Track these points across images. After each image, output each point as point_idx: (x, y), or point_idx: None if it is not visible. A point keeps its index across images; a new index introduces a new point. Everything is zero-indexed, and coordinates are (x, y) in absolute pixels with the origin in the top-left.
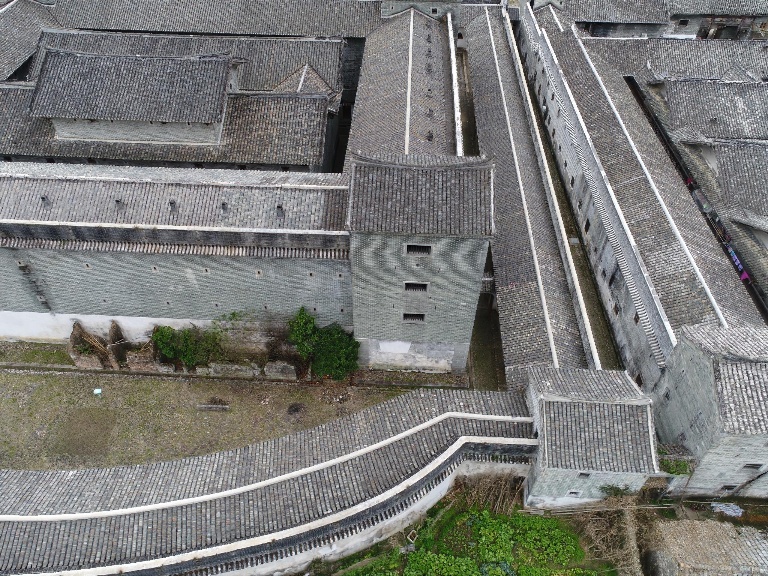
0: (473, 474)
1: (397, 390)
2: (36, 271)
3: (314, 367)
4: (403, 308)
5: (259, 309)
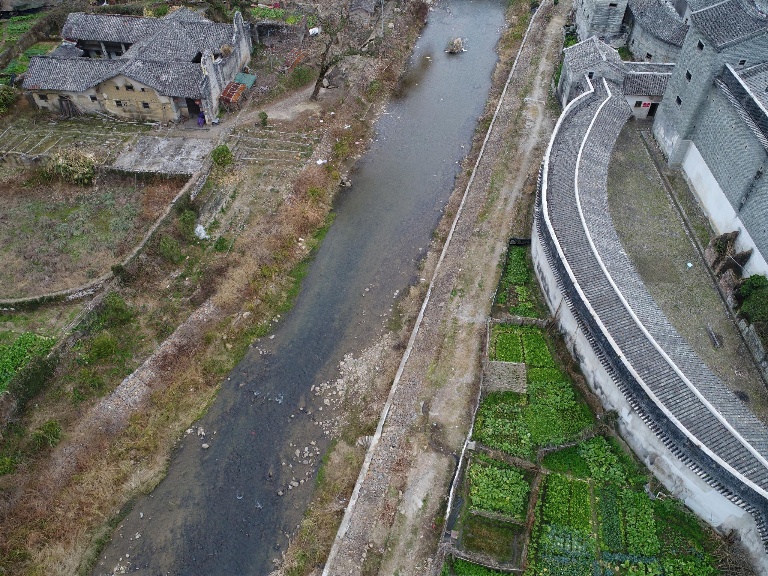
0: (745, 544)
1: None
2: (761, 180)
3: None
4: None
5: None
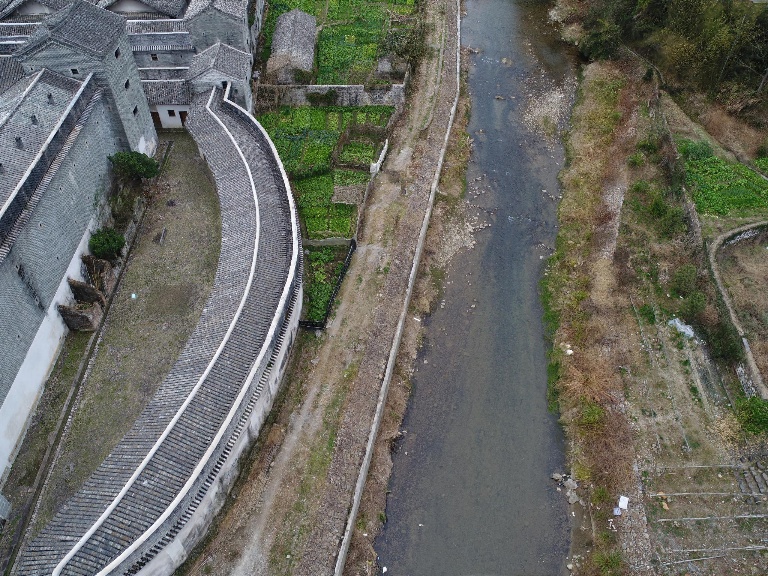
0: None
1: (165, 167)
2: (25, 267)
3: (149, 176)
4: (131, 107)
5: (98, 180)
